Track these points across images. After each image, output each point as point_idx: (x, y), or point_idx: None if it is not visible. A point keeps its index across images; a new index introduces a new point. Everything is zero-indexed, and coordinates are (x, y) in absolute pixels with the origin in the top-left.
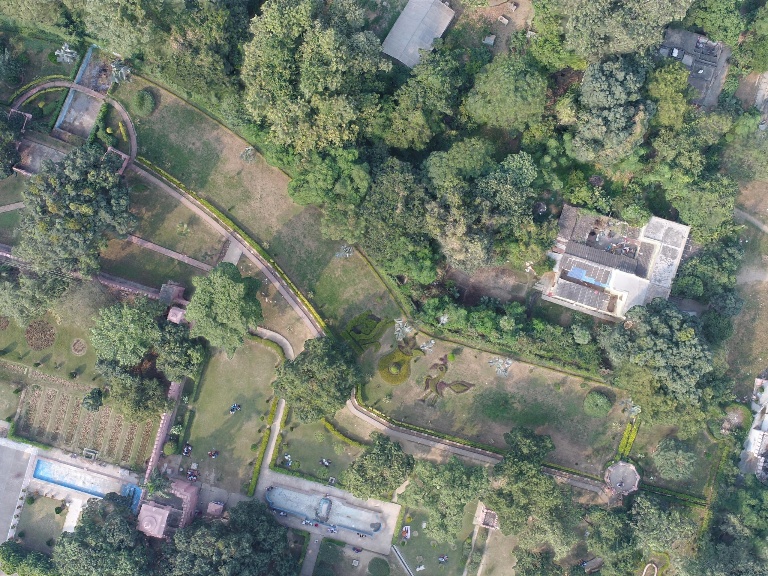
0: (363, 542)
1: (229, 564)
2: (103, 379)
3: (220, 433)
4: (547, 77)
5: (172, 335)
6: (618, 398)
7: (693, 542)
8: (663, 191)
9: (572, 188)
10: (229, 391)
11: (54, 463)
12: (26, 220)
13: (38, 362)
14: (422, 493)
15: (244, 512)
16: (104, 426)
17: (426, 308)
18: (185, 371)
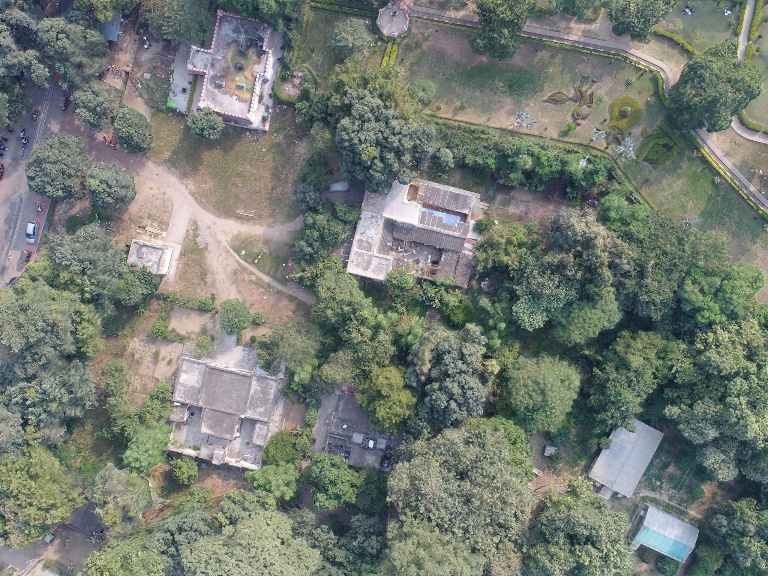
0: None
1: None
2: None
3: None
4: (499, 412)
5: None
6: None
7: None
8: None
9: None
10: None
11: None
12: None
13: None
14: None
15: None
16: None
17: None
18: None
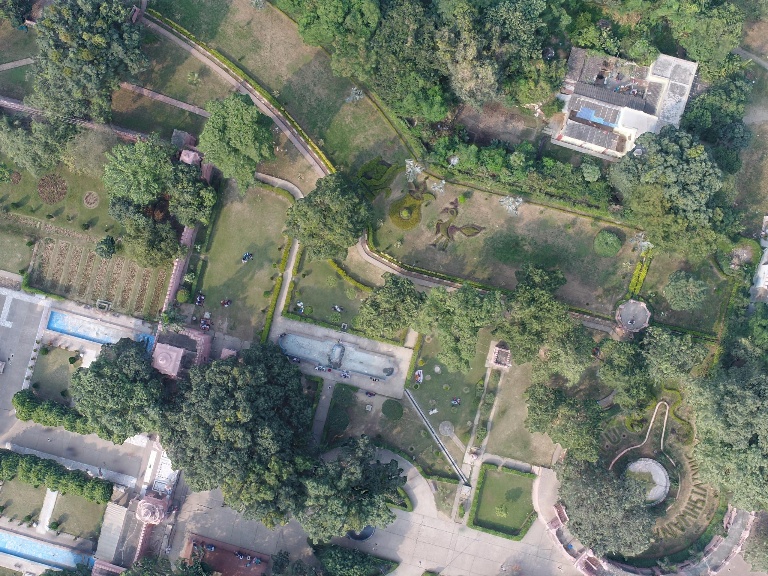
0: (376, 387)
1: (245, 390)
2: (115, 231)
3: (232, 282)
4: None
5: (185, 174)
6: (628, 238)
7: (704, 379)
8: (670, 33)
9: (580, 30)
10: (241, 240)
11: (68, 315)
12: (39, 55)
13: (51, 215)
14: (436, 316)
15: (258, 349)
16: (117, 277)
17: (436, 148)
18: (198, 213)
